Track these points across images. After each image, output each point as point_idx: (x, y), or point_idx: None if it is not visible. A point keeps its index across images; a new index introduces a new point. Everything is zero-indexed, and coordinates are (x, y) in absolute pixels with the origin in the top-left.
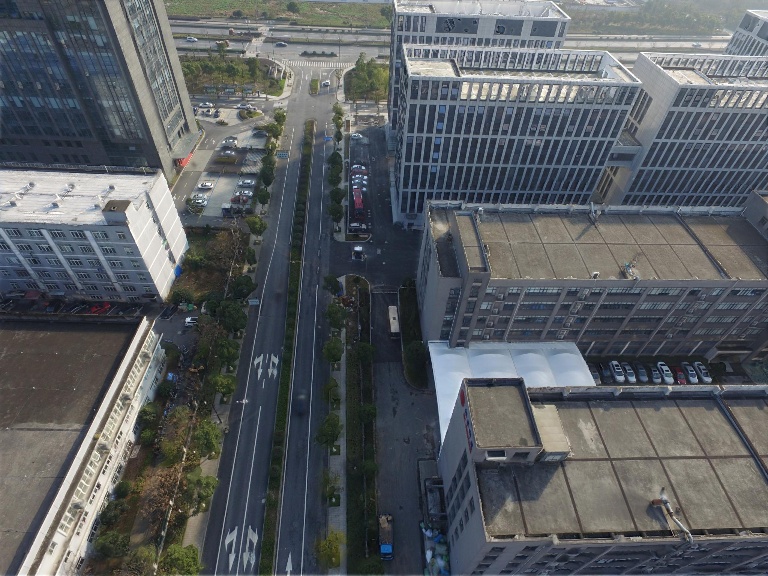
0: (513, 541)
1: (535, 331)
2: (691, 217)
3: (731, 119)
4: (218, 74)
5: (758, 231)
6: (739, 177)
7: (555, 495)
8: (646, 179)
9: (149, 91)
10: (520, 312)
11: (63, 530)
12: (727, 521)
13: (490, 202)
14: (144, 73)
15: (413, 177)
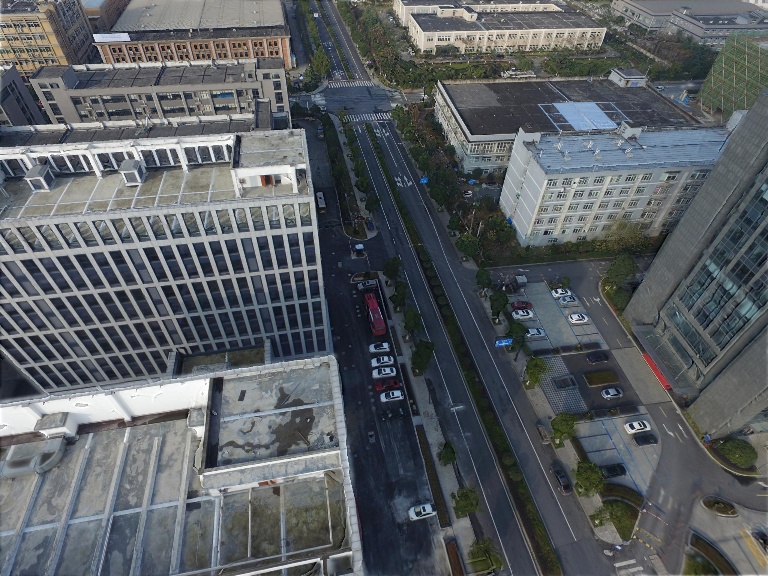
0: None
1: None
2: None
3: None
4: None
5: None
6: None
7: None
8: None
9: (695, 248)
10: None
11: None
12: None
13: None
14: (712, 232)
15: None
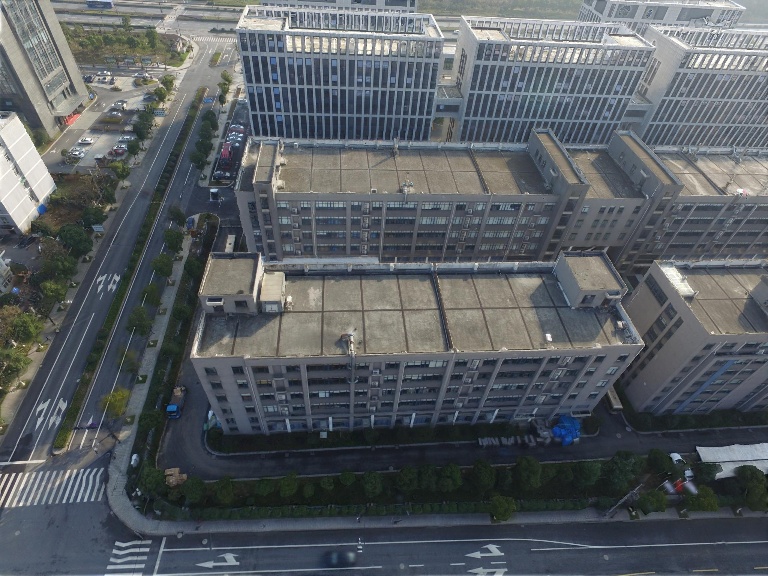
0: (211, 357)
1: (341, 247)
2: (482, 152)
3: (531, 72)
4: (120, 46)
5: (534, 162)
6: (554, 127)
7: (266, 334)
8: (473, 129)
9: (20, 49)
10: (318, 227)
11: None
12: (397, 348)
13: None
14: (13, 32)
15: (262, 126)
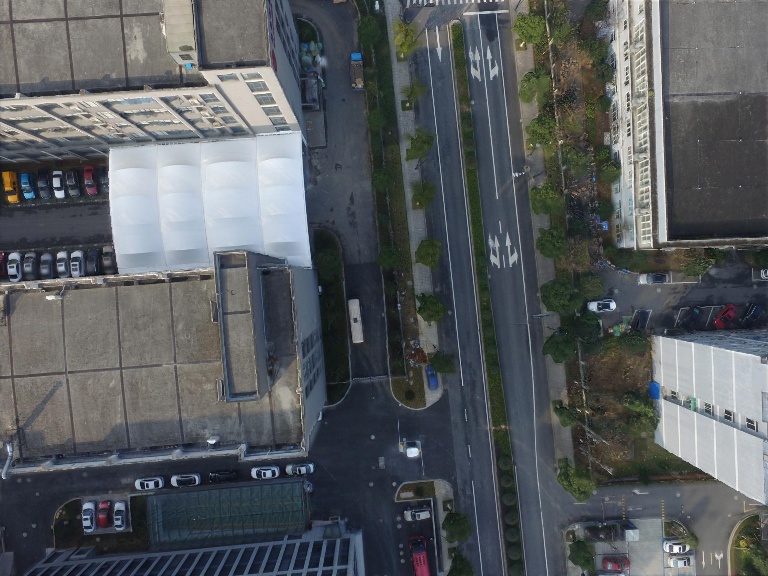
0: None
1: None
2: None
3: None
4: None
5: None
6: None
7: None
8: None
9: None
10: None
11: (639, 25)
12: None
13: (193, 568)
14: None
15: None
